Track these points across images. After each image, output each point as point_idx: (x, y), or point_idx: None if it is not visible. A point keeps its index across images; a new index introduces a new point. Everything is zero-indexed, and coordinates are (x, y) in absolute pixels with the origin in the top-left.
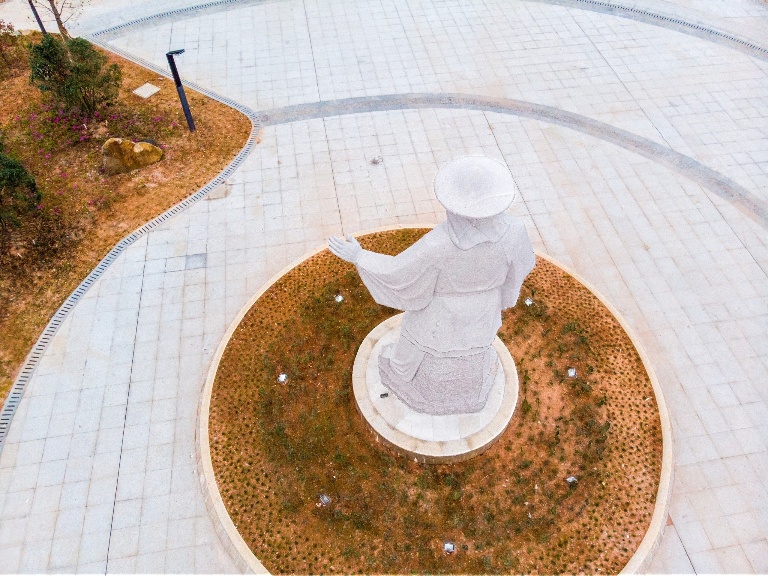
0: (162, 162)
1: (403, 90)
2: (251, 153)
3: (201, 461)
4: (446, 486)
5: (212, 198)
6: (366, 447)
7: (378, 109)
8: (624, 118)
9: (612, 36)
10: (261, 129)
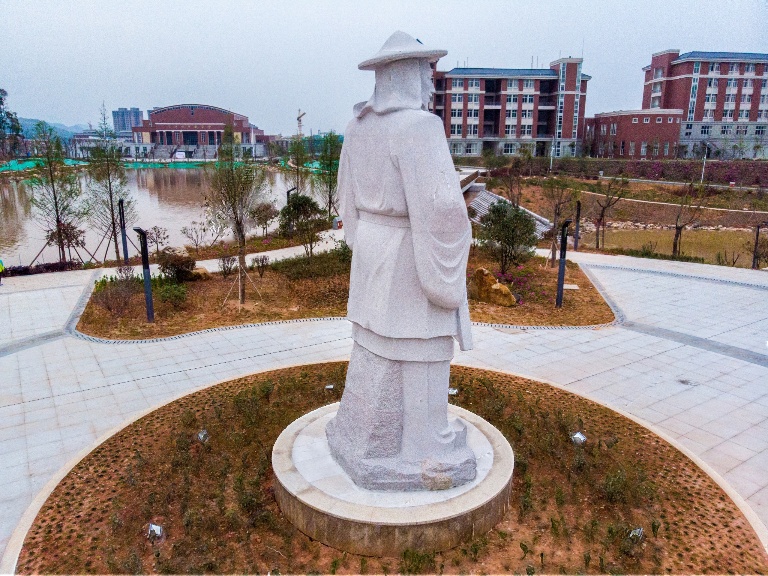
0: (507, 307)
1: None
2: (576, 330)
3: None
4: (248, 516)
5: (500, 330)
6: None
7: (766, 365)
8: None
9: None
10: (612, 326)
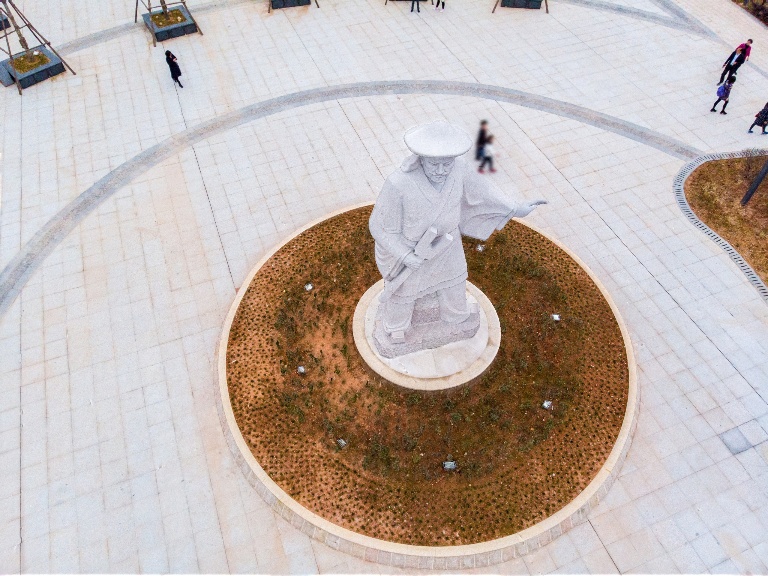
0: None
1: None
2: None
3: None
4: None
5: None
6: None
7: None
8: None
9: None
10: None
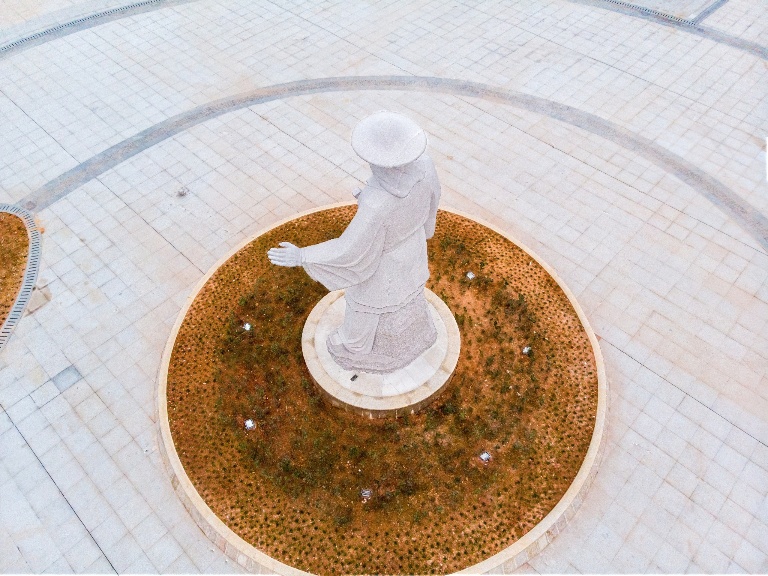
0: None
1: (158, 119)
2: (43, 246)
3: (230, 545)
4: (448, 415)
5: (34, 310)
6: (367, 429)
7: (147, 146)
8: (364, 66)
9: (307, 4)
10: (35, 218)
